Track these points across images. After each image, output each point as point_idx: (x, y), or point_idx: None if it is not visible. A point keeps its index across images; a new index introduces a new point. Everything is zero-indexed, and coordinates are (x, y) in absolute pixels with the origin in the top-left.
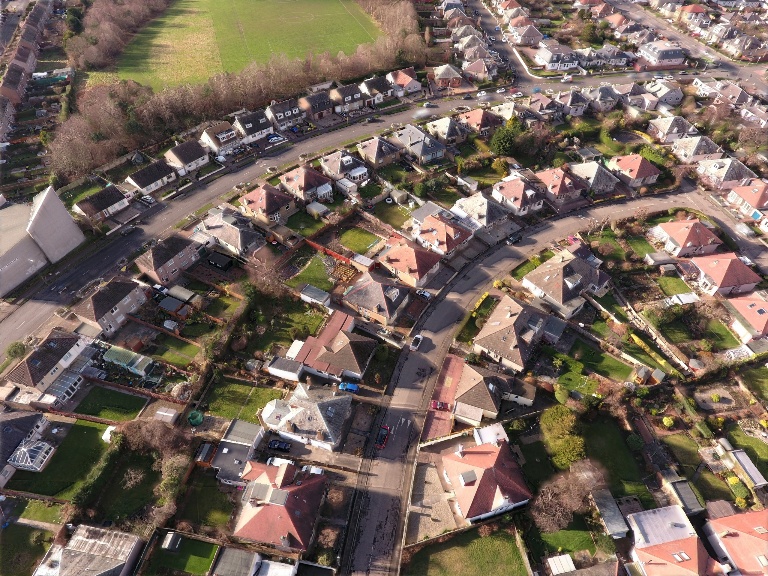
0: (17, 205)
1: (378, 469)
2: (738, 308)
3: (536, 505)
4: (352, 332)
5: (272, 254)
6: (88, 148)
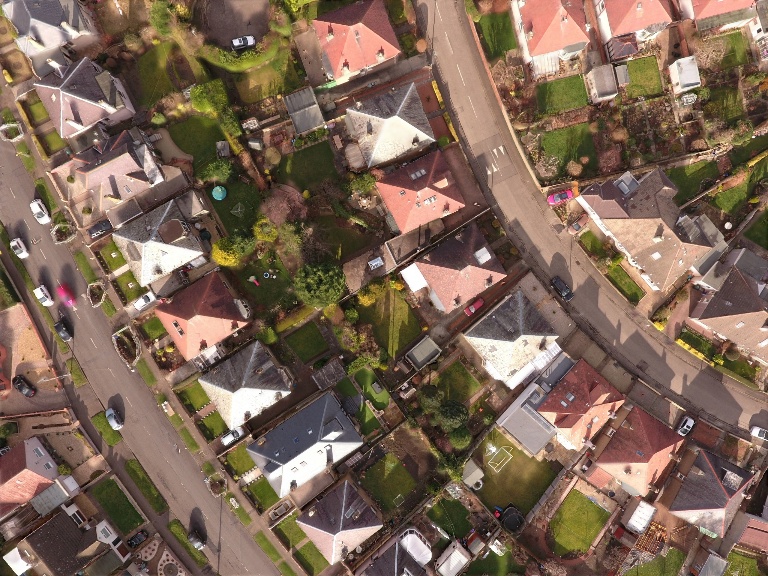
0: None
1: None
2: (714, 14)
3: None
4: (749, 513)
5: None
6: None
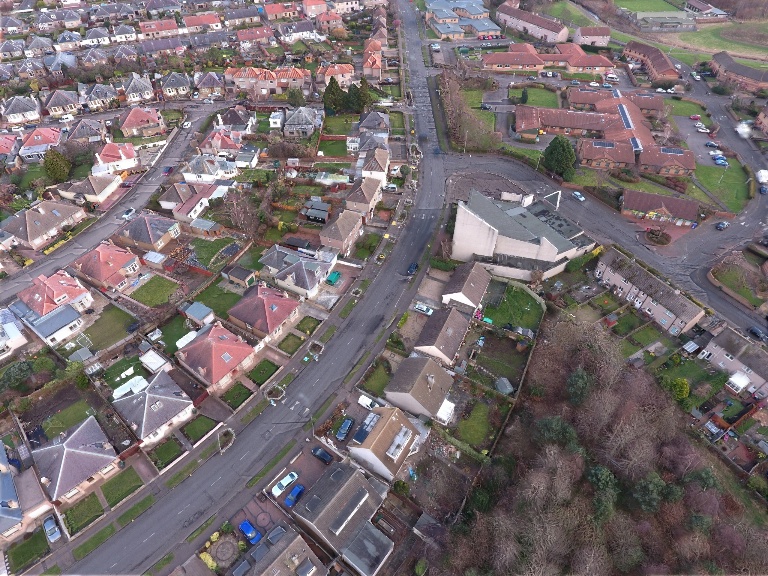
0: (521, 239)
1: (174, 163)
2: None
3: (93, 143)
4: None
5: (251, 263)
6: (558, 346)
